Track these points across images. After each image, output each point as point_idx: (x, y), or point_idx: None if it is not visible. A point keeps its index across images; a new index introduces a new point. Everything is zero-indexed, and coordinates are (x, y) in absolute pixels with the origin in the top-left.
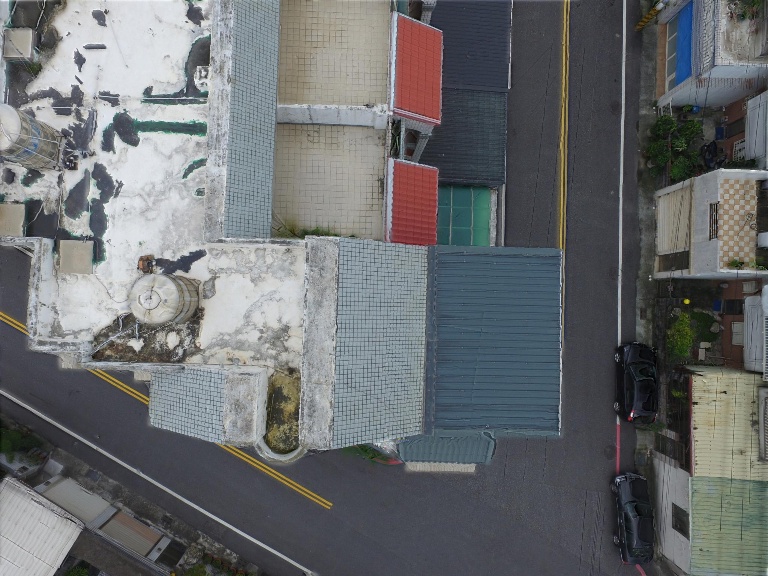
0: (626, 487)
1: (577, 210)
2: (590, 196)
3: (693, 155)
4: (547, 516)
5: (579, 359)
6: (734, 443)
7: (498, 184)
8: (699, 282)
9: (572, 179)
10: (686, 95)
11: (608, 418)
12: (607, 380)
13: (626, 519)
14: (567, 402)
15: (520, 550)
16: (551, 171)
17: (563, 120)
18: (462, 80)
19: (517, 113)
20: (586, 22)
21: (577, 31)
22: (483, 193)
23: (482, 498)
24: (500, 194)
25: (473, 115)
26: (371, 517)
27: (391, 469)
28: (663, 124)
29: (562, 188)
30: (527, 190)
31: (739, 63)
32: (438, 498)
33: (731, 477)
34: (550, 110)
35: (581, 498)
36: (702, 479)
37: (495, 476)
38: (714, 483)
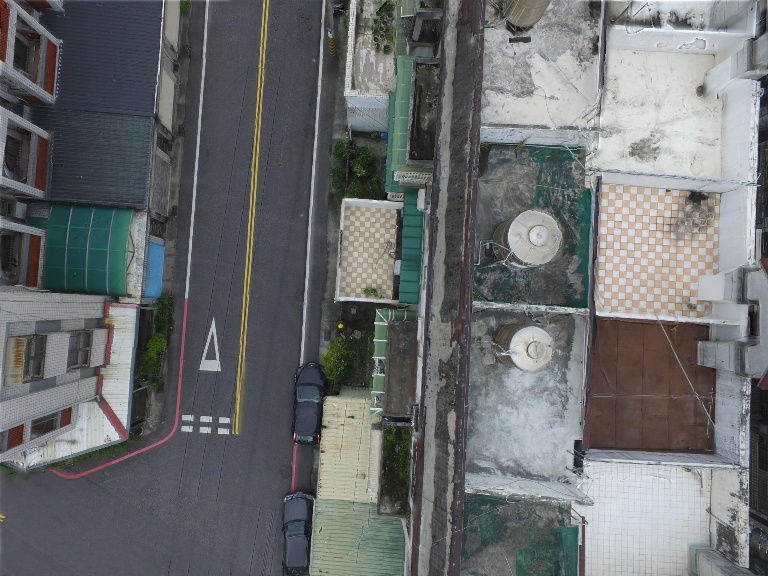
0: (302, 506)
1: (265, 232)
2: (279, 218)
3: (373, 181)
4: (218, 533)
5: (259, 379)
6: (359, 467)
7: (139, 207)
8: (381, 305)
9: (261, 201)
10: (361, 122)
11: (284, 437)
12: (287, 400)
13: (284, 538)
14: (244, 421)
15: (190, 566)
16: (241, 192)
17: (255, 142)
18: (106, 103)
19: (211, 134)
20: (283, 46)
21: (274, 55)
22: (124, 215)
23: (156, 514)
24: (190, 214)
25: (115, 138)
26: (44, 530)
27: (68, 483)
28: (337, 150)
29: (250, 210)
30: (217, 211)
31: (367, 95)
32: (112, 513)
33: (353, 500)
34: (244, 132)
35: (254, 516)
36: (327, 501)
37: (169, 492)
38: (338, 506)
